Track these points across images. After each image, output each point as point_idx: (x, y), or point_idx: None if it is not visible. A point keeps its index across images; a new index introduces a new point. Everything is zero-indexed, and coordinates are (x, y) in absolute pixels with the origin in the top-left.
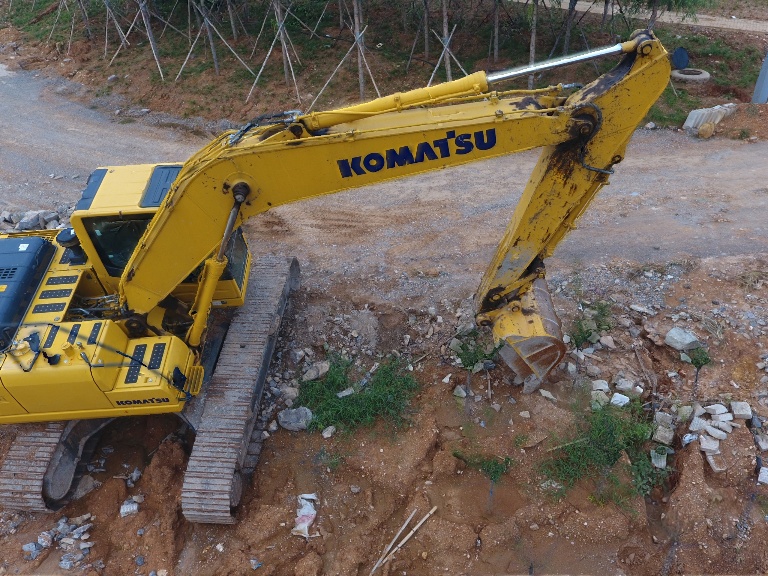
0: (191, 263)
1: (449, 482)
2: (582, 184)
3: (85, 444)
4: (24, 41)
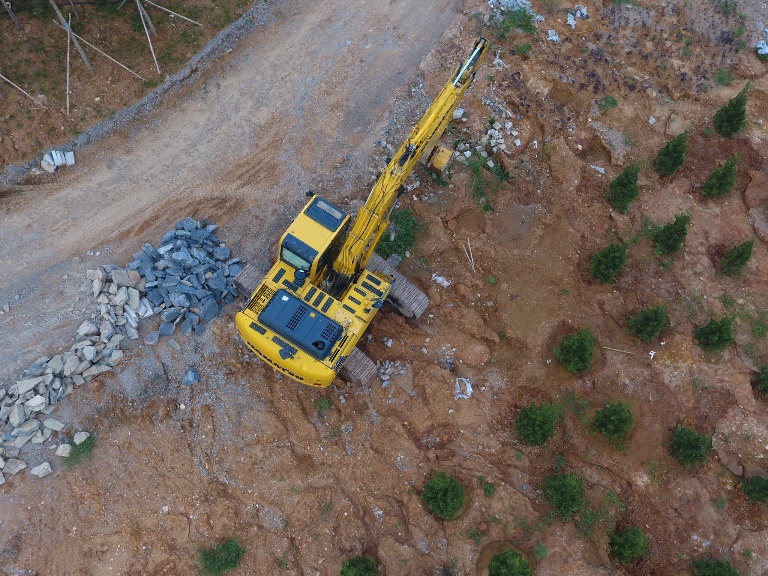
0: None
1: (459, 229)
2: None
3: None
4: None
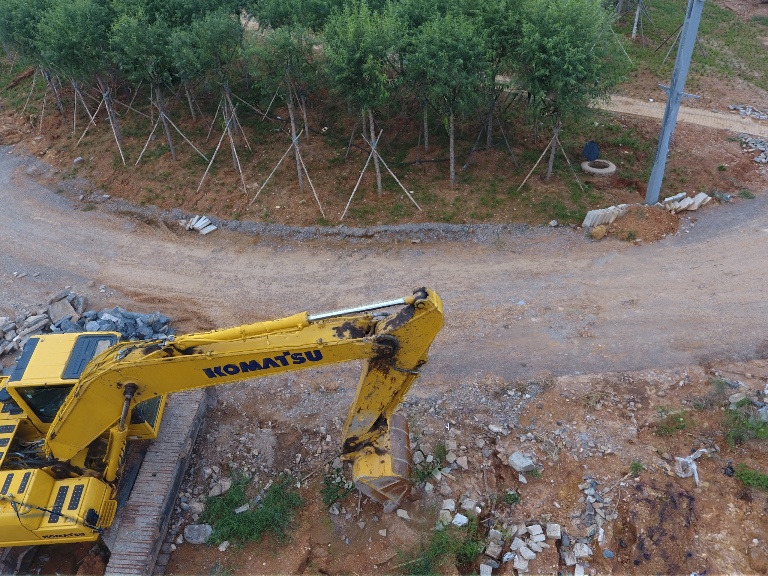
0: (101, 428)
1: None
2: (399, 377)
3: (23, 558)
4: (1, 110)
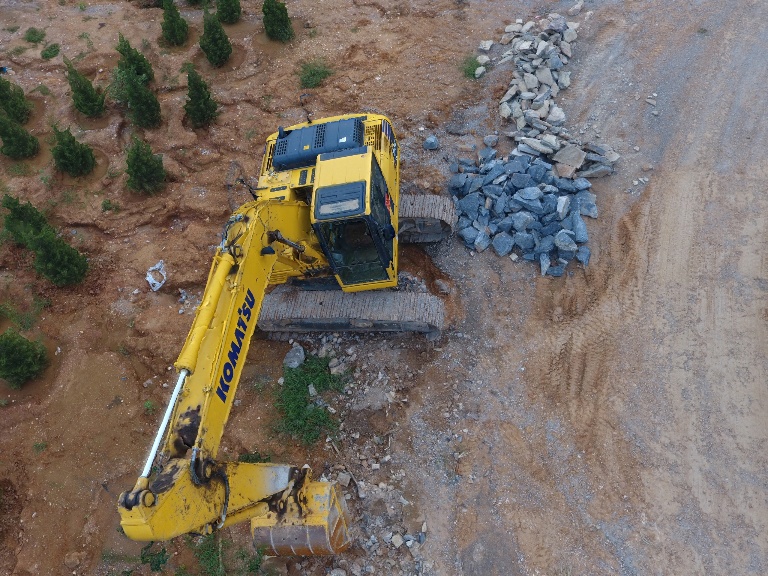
0: None
1: None
2: None
3: None
4: None
